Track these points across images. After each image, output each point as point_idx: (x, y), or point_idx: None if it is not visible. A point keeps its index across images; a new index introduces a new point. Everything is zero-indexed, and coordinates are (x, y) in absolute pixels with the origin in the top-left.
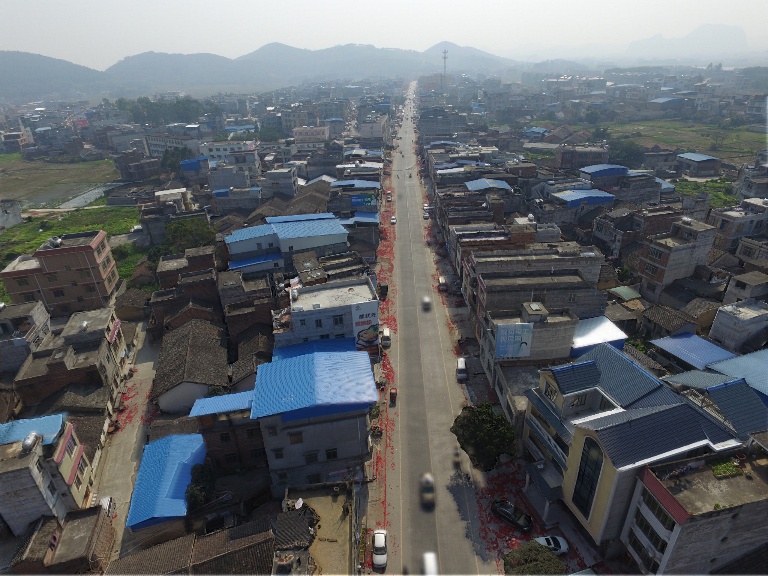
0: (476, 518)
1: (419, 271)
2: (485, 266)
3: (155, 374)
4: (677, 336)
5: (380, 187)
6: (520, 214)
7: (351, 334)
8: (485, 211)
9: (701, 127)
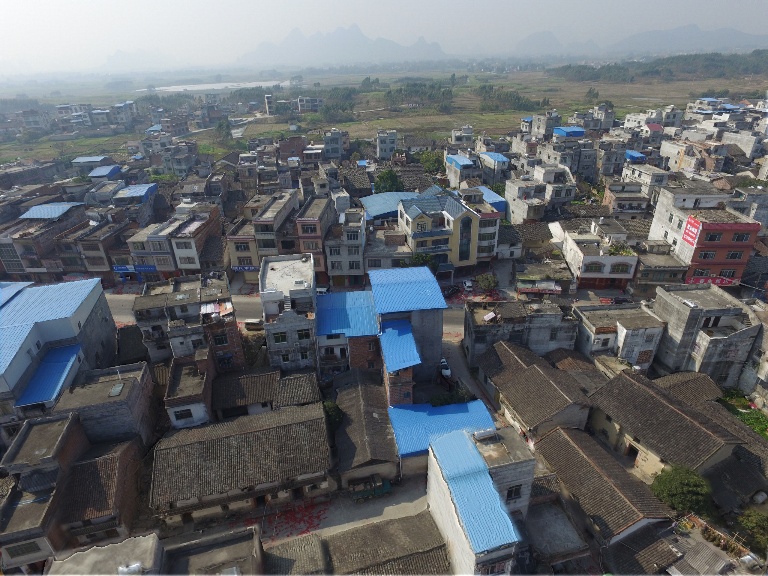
0: (451, 304)
1: (128, 304)
2: (276, 219)
3: (265, 483)
4: None
5: None
6: None
7: None
8: (111, 224)
9: (3, 146)
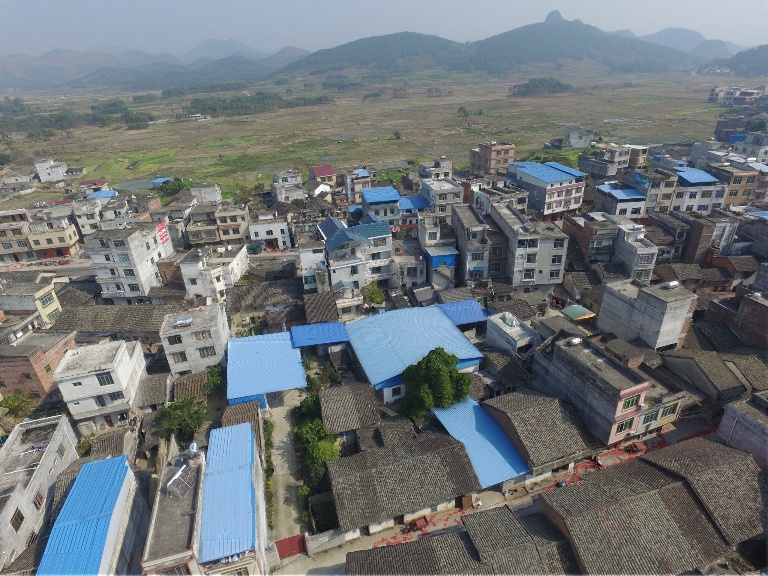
0: None
1: None
2: None
3: None
4: (486, 311)
5: (729, 188)
6: (753, 259)
7: (430, 204)
8: None
9: None
